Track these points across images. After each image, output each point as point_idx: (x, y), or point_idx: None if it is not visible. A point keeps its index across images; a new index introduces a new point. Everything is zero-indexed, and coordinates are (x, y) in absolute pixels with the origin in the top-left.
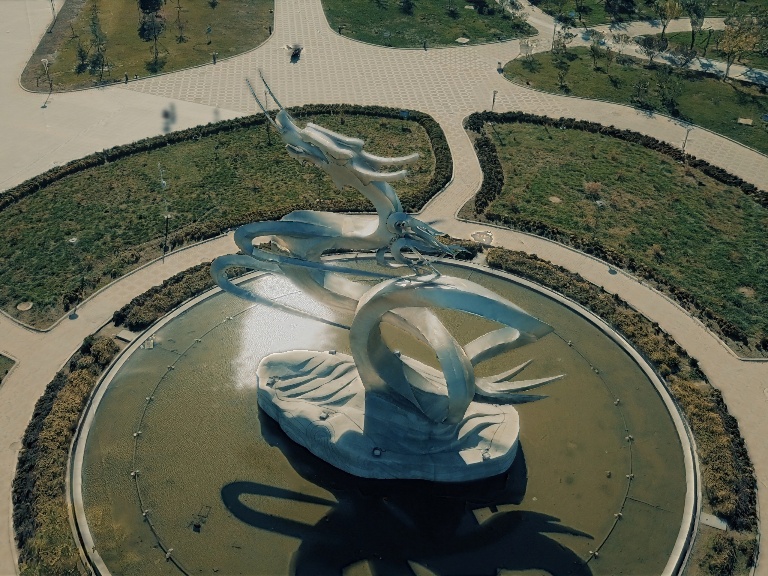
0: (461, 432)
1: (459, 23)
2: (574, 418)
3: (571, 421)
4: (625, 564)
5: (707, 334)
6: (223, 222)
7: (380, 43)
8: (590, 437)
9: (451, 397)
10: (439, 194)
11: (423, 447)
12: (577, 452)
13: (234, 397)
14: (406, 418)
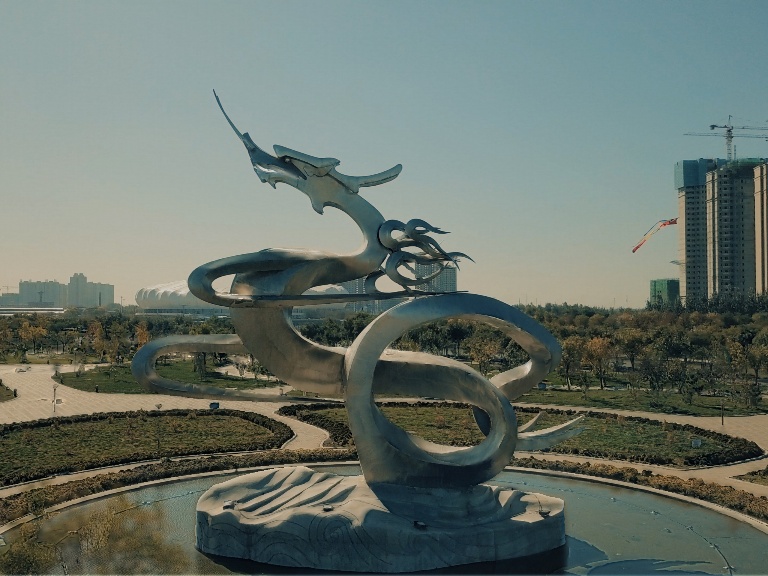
0: (501, 500)
1: (219, 383)
2: (586, 513)
3: (585, 515)
4: (767, 569)
5: (636, 465)
6: (45, 469)
7: (147, 393)
8: (617, 520)
9: (503, 408)
10: (291, 441)
11: (467, 520)
12: (618, 526)
13: (164, 557)
14: (431, 496)
